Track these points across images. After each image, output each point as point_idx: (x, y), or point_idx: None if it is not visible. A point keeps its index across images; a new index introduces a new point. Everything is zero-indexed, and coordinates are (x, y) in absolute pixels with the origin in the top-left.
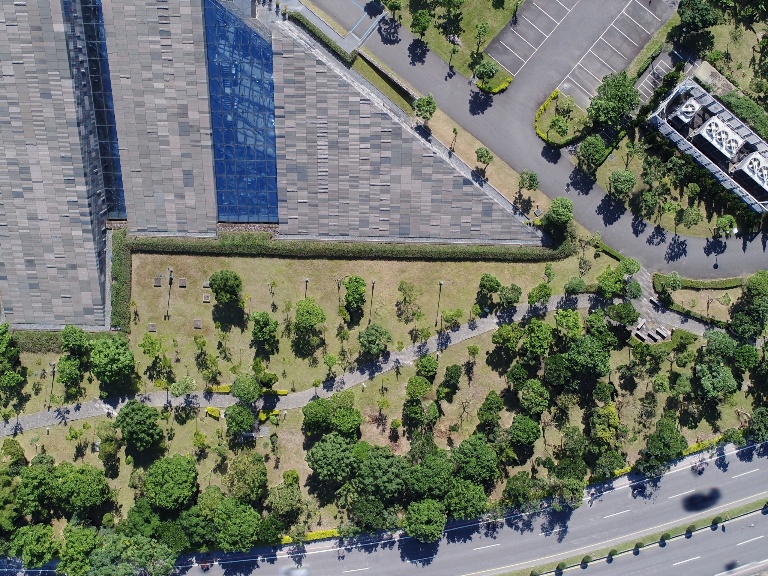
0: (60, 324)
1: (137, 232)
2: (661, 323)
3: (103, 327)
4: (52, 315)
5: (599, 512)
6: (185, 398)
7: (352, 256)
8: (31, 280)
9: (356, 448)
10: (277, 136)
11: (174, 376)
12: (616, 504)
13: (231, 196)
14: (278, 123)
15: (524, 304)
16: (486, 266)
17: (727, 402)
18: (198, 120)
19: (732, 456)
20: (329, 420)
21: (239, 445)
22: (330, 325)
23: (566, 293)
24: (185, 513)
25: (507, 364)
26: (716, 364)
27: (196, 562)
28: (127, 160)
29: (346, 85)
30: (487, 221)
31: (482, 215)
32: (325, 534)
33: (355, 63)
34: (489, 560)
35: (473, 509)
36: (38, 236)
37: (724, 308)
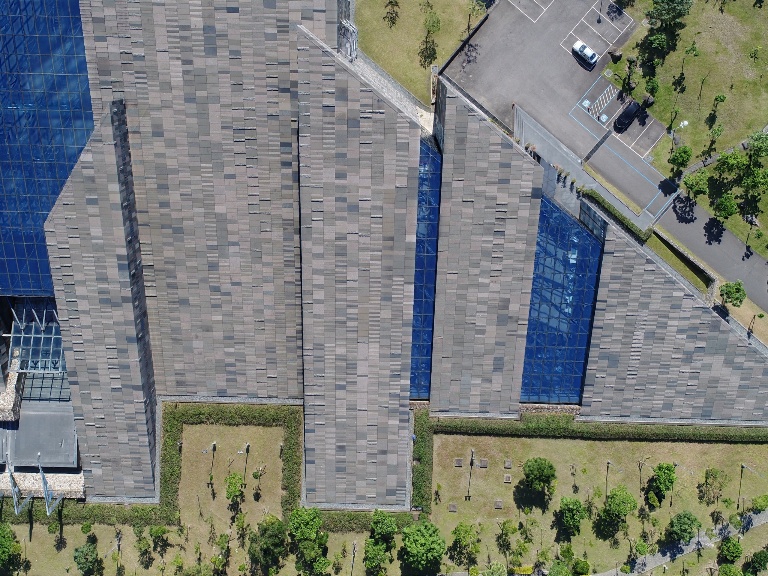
0: (360, 503)
1: (438, 412)
2: None
3: (403, 507)
4: (354, 495)
5: None
6: None
7: (655, 439)
8: (339, 464)
9: None
10: (595, 327)
11: (475, 557)
12: None
13: None
14: (598, 315)
15: None
16: None
17: None
18: (518, 312)
19: None
20: None
21: None
22: None
23: None
24: None
25: None
26: None
27: None
28: (440, 347)
29: (672, 282)
30: None
31: None
32: None
33: (649, 240)
34: None
35: None
36: (354, 424)
37: None
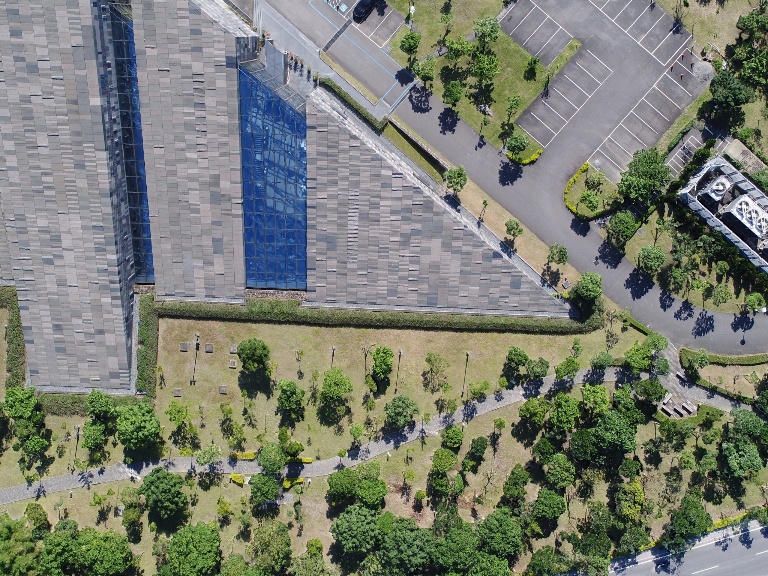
0: (85, 387)
1: (165, 296)
2: (687, 398)
3: (128, 391)
4: (78, 378)
5: None
6: (209, 464)
7: (379, 325)
8: (58, 344)
9: (381, 520)
10: (308, 207)
11: (199, 441)
12: None
13: (259, 261)
14: (310, 194)
15: (551, 376)
16: (513, 337)
17: (753, 481)
18: (230, 190)
19: (756, 533)
20: (354, 491)
21: (262, 512)
22: (356, 393)
23: (593, 366)
24: None
25: (532, 436)
26: (743, 443)
27: None
28: (157, 227)
29: (379, 159)
30: (515, 293)
31: (510, 287)
32: None
33: (385, 130)
34: None
35: None
36: (67, 302)
37: (750, 384)
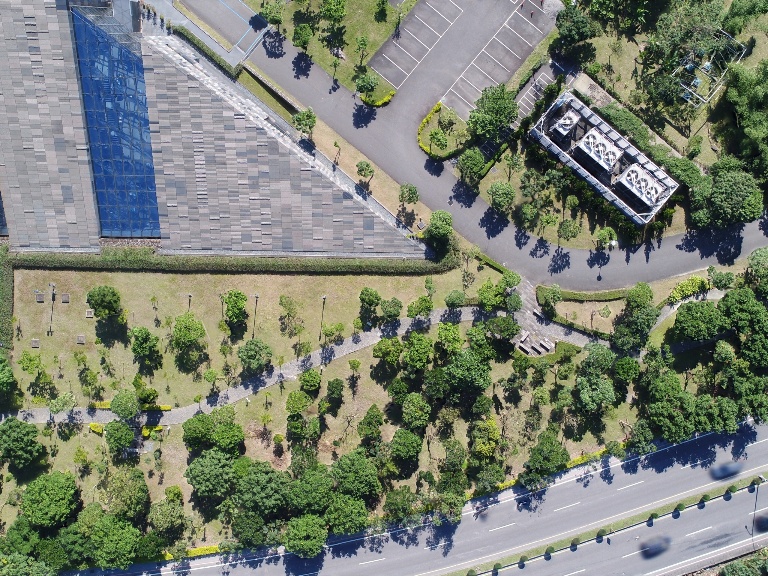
0: None
1: (20, 248)
2: (545, 335)
3: None
4: None
5: (484, 525)
6: (68, 414)
7: (235, 270)
8: None
9: (236, 463)
10: (153, 151)
11: (57, 392)
12: (501, 517)
13: (116, 211)
14: (154, 138)
15: (408, 317)
16: (370, 279)
17: (608, 414)
18: (73, 136)
19: (617, 468)
20: (209, 436)
21: (123, 461)
22: (214, 340)
23: None
24: (64, 530)
25: (391, 378)
26: (595, 377)
27: None
28: (5, 176)
29: (219, 100)
30: (369, 234)
31: (364, 228)
32: (209, 550)
33: (240, 77)
34: (374, 575)
35: (352, 524)
36: None
37: (608, 320)
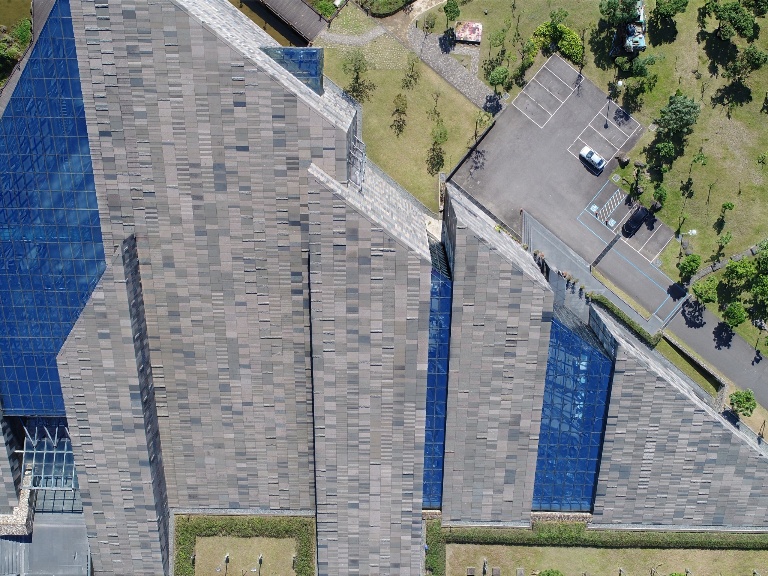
0: None
1: (450, 522)
2: None
3: None
4: None
5: None
6: None
7: (667, 546)
8: None
9: None
10: (606, 441)
11: None
12: None
13: None
14: (609, 430)
15: None
16: None
17: None
18: (529, 427)
19: None
20: None
21: None
22: None
23: None
24: None
25: None
26: None
27: None
28: (451, 461)
29: (683, 398)
30: None
31: None
32: None
33: (658, 345)
34: None
35: None
36: (366, 540)
37: None
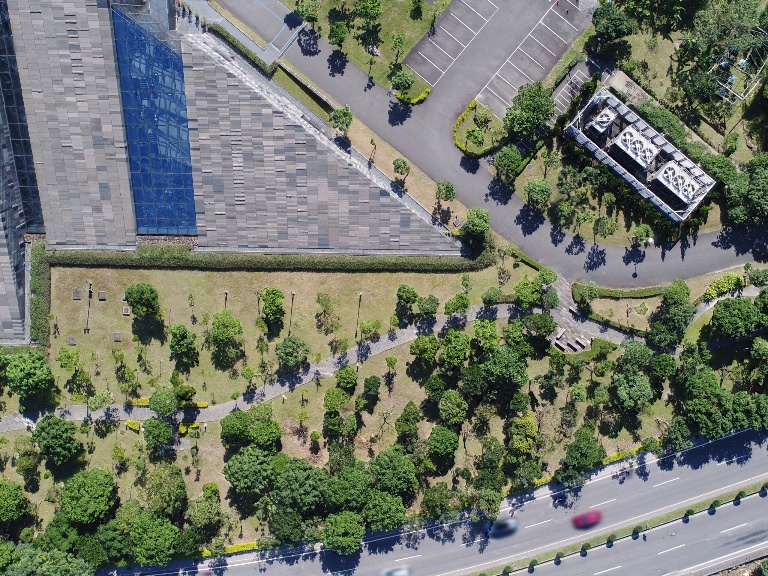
0: None
1: (56, 245)
2: (581, 332)
3: (23, 341)
4: None
5: (520, 522)
6: (105, 411)
7: (271, 268)
8: None
9: (274, 460)
10: (191, 149)
11: (94, 389)
12: (537, 514)
13: (151, 208)
14: (192, 136)
15: None
16: (405, 277)
17: (644, 411)
18: (112, 133)
19: (653, 465)
20: (247, 433)
21: (160, 458)
22: (250, 337)
23: None
24: (102, 527)
25: (427, 375)
26: (632, 373)
27: (117, 575)
28: (43, 174)
29: (258, 98)
30: (405, 232)
31: (400, 226)
32: (246, 547)
33: (275, 74)
34: (411, 571)
35: (390, 521)
36: None
37: (643, 317)
